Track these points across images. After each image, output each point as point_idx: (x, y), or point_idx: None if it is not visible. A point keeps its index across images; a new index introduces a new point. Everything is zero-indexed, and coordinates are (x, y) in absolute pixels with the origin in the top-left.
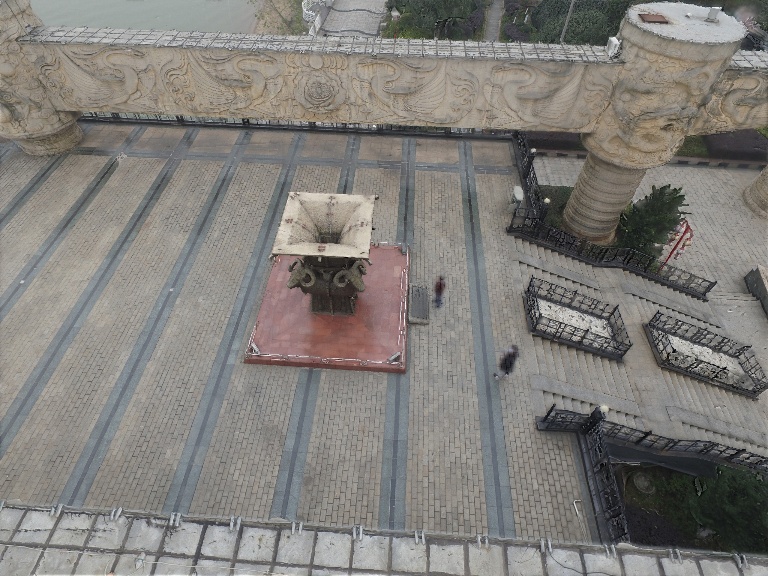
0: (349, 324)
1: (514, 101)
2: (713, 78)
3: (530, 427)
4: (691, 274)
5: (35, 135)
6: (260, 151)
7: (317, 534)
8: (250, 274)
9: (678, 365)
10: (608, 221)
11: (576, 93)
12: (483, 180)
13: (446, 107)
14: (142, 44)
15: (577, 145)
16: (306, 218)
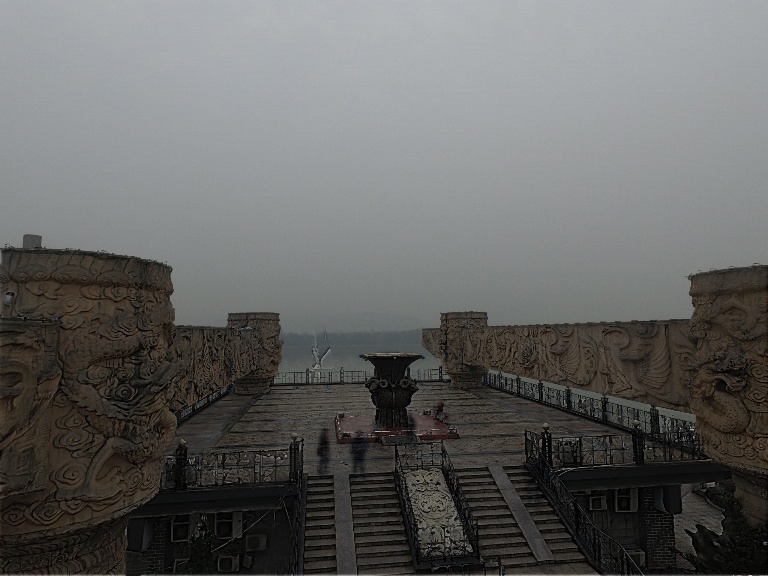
0: None
1: (619, 363)
2: (765, 317)
3: None
4: None
5: (449, 371)
6: None
7: None
8: None
9: None
10: None
11: (667, 357)
12: None
13: (583, 369)
14: (484, 326)
15: None
16: None
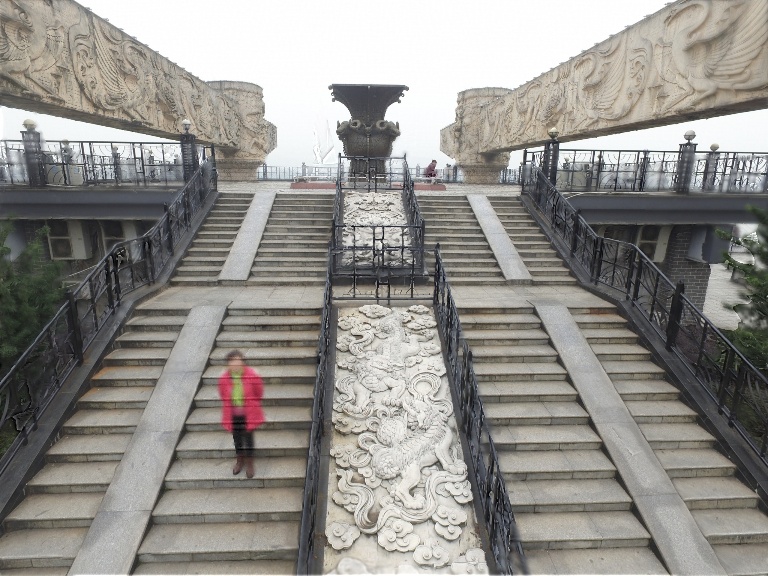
0: None
1: (682, 59)
2: None
3: None
4: None
5: (462, 163)
6: None
7: None
8: None
9: None
10: None
11: None
12: None
13: (624, 96)
14: None
15: None
16: None
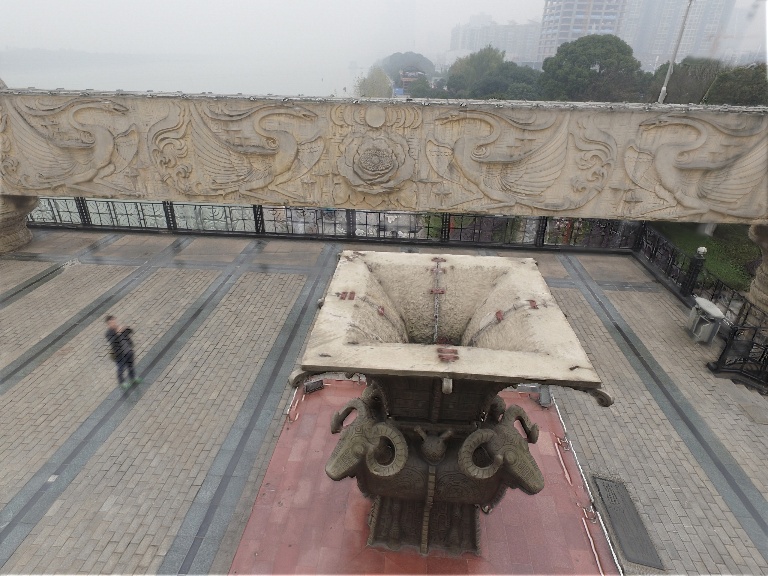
0: None
1: (671, 174)
2: None
3: None
4: None
5: None
6: (276, 260)
7: None
8: (233, 444)
9: None
10: None
11: (767, 162)
12: (620, 298)
13: (564, 186)
14: (127, 94)
15: None
16: (382, 297)
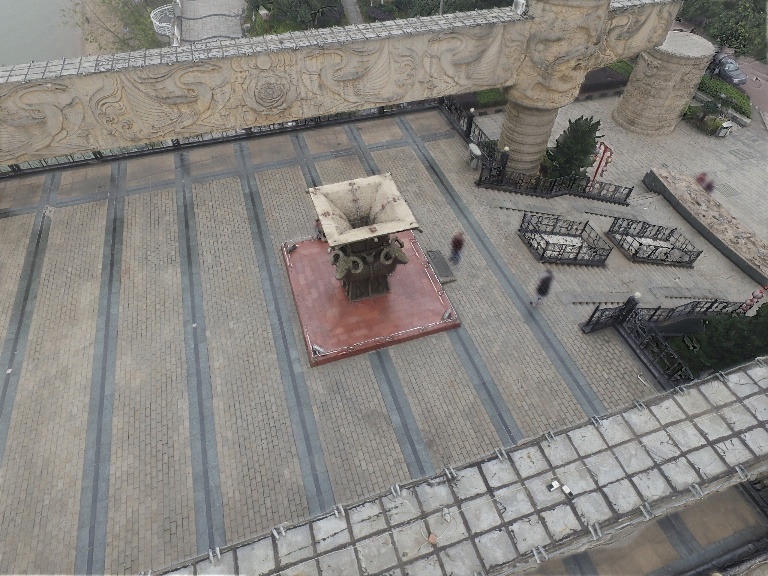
0: (391, 301)
1: (450, 68)
2: (603, 19)
3: (578, 334)
4: (616, 185)
5: None
6: (207, 169)
7: (568, 435)
8: (268, 286)
9: (642, 256)
10: (536, 160)
11: (499, 51)
12: (433, 147)
13: (391, 85)
14: (64, 75)
15: (476, 104)
16: (336, 209)
